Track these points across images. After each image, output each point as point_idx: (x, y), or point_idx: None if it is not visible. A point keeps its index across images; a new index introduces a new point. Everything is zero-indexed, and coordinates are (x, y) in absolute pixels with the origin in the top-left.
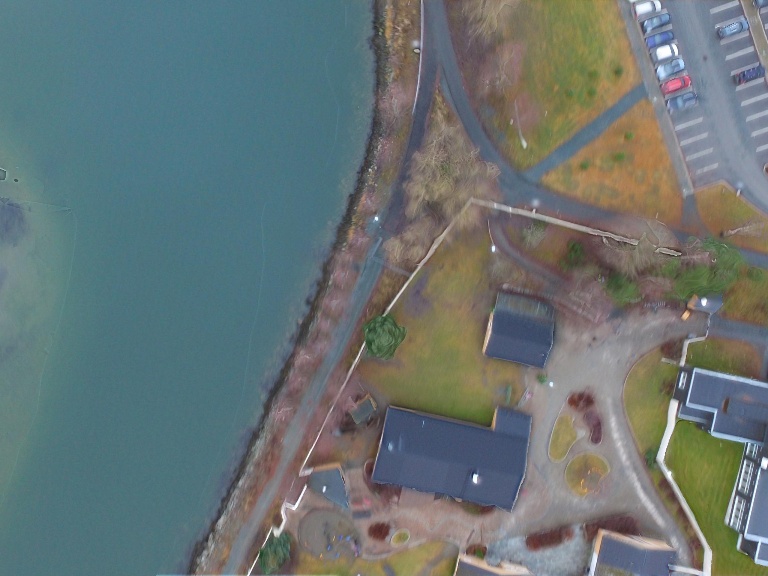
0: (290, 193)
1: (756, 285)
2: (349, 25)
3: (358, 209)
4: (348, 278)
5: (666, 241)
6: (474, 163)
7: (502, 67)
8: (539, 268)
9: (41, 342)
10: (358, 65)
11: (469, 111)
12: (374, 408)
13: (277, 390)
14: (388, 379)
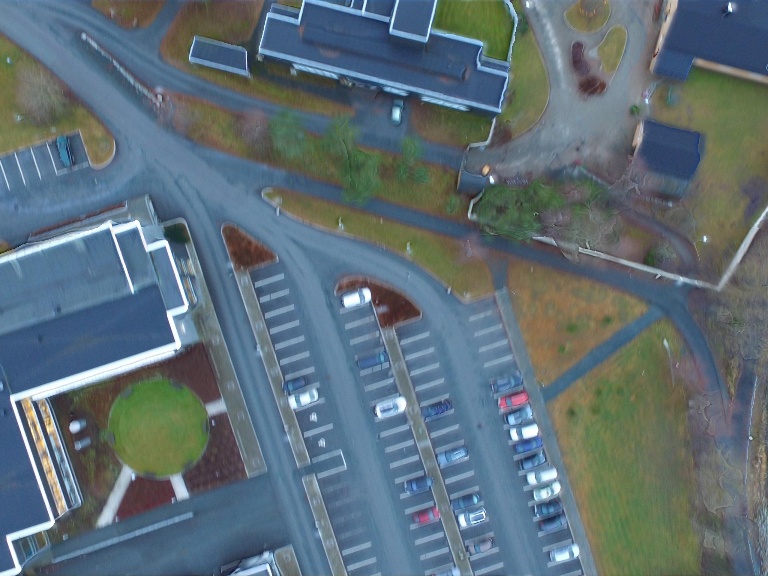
0: None
1: (428, 197)
2: None
3: None
4: None
5: None
6: None
7: (686, 419)
8: (642, 221)
9: None
10: None
11: (707, 378)
12: None
13: None
14: None
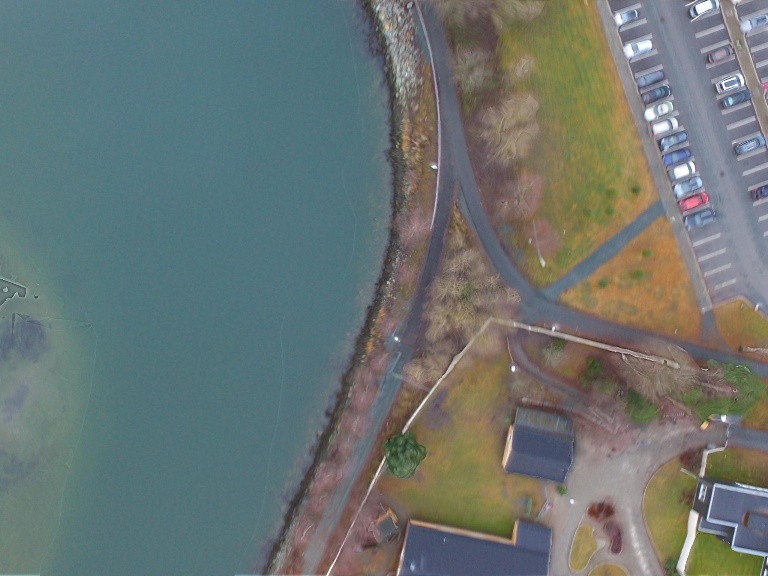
0: (309, 305)
1: None
2: (366, 136)
3: (377, 321)
4: (368, 393)
5: (687, 370)
6: (494, 291)
7: (520, 187)
8: (558, 382)
9: (62, 457)
10: (375, 176)
11: (487, 227)
12: (395, 526)
13: (297, 502)
14: (408, 492)
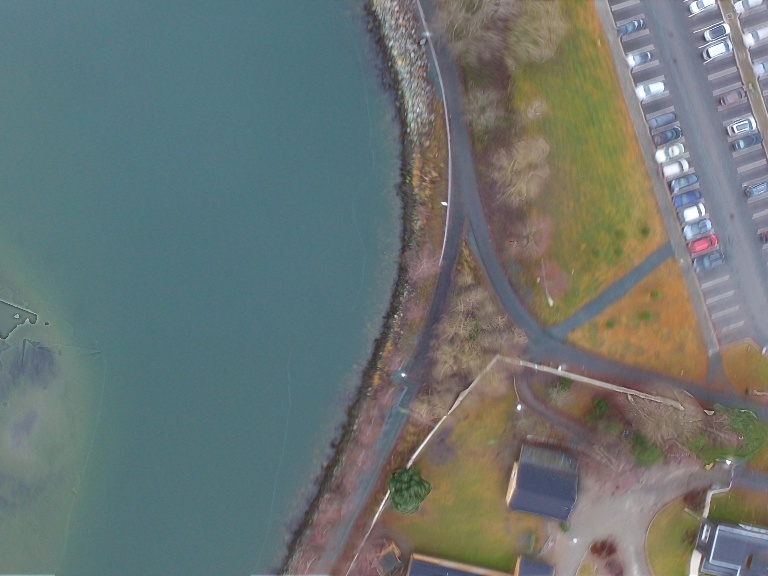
0: (316, 337)
1: None
2: (376, 170)
3: (383, 354)
4: (373, 426)
5: (693, 416)
6: (502, 332)
7: (529, 226)
8: (564, 420)
9: (69, 483)
10: (385, 209)
11: (496, 265)
12: (398, 561)
13: (301, 532)
14: (412, 526)
